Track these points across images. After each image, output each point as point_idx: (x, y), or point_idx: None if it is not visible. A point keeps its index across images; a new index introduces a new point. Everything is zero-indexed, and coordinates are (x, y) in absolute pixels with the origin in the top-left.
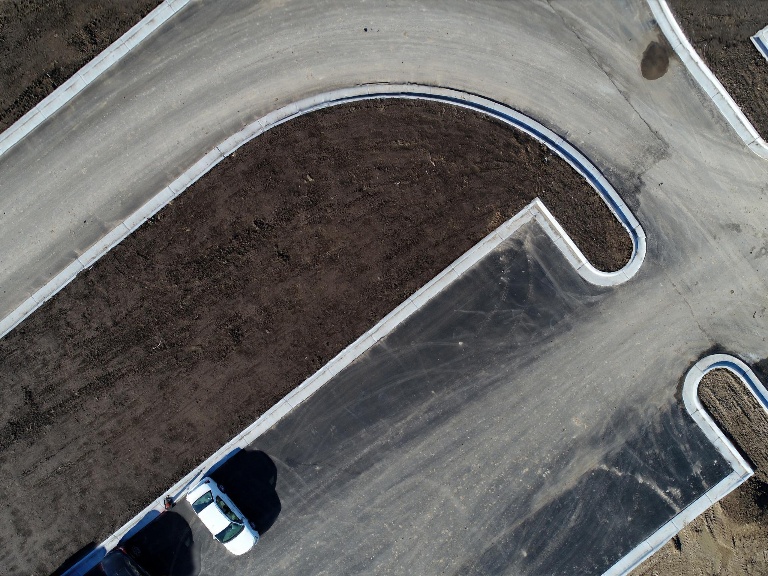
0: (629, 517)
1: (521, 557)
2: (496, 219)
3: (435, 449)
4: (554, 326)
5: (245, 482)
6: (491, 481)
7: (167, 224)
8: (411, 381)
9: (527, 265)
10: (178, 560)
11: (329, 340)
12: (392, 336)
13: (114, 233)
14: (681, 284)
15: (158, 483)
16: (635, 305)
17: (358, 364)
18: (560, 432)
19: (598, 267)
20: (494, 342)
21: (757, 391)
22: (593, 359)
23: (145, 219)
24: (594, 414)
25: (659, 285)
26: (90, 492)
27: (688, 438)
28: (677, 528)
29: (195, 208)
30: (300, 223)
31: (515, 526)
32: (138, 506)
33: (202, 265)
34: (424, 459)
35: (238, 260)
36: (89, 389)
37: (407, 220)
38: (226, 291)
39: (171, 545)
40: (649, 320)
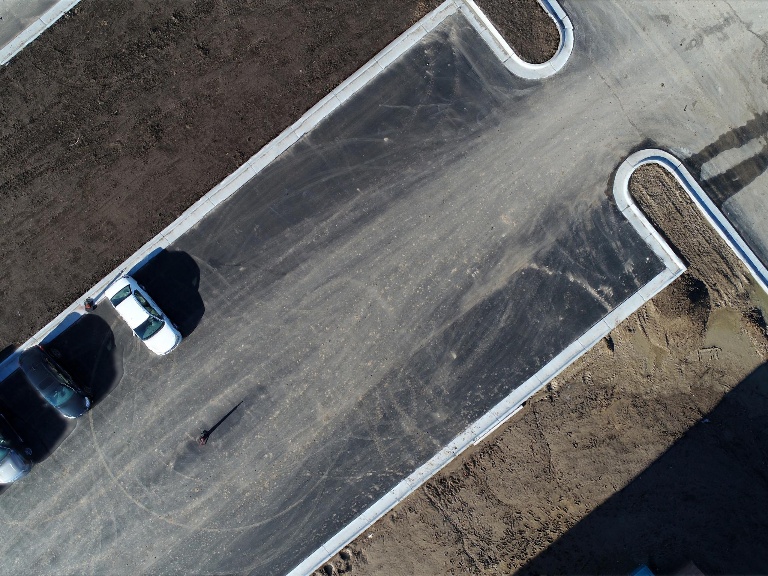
0: (560, 317)
1: (451, 359)
2: (420, 9)
3: (361, 248)
4: (481, 121)
5: (167, 283)
6: (419, 281)
7: (84, 18)
8: (336, 179)
9: (452, 58)
10: (100, 364)
11: (251, 135)
12: (316, 132)
13: (31, 29)
14: (610, 77)
15: (78, 283)
16: (563, 99)
17: (281, 161)
18: (489, 230)
19: (525, 59)
20: (420, 138)
21: (689, 186)
22: (521, 155)
23: (62, 13)
24: (523, 211)
25: (588, 78)
26: (8, 293)
27: (619, 235)
28: (609, 327)
29: (112, 1)
30: (220, 15)
31: (444, 328)
32: (58, 307)
33: (120, 59)
34: (350, 259)
35: (157, 54)
36: (6, 188)
37: (329, 11)
38: (145, 85)
39: (92, 349)
40: (578, 114)
